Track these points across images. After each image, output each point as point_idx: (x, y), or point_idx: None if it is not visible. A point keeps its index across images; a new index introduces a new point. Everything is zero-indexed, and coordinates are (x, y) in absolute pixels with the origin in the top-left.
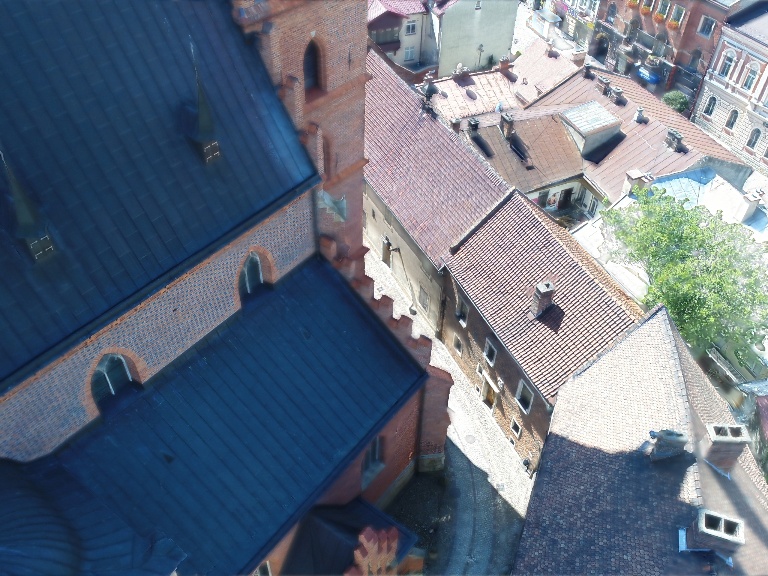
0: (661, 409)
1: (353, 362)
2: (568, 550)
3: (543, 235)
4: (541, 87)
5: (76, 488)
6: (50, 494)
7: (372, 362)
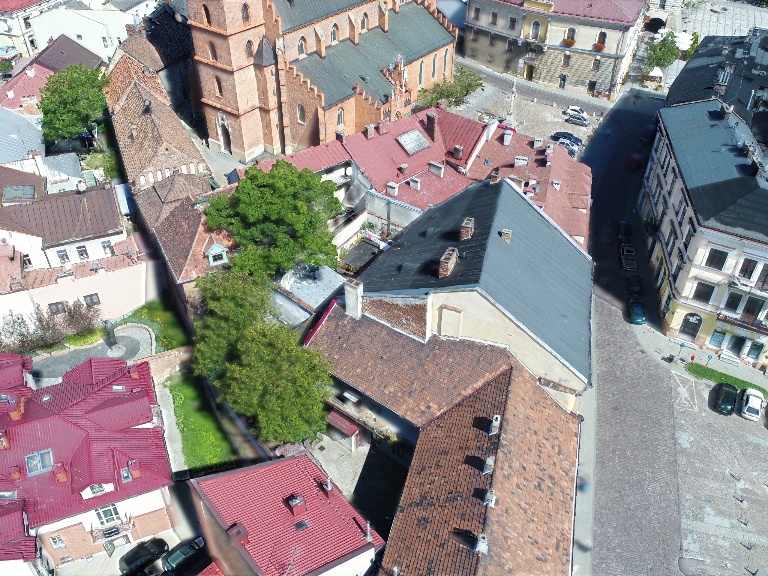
0: None
1: None
2: None
3: None
4: (12, 251)
5: None
6: None
7: None
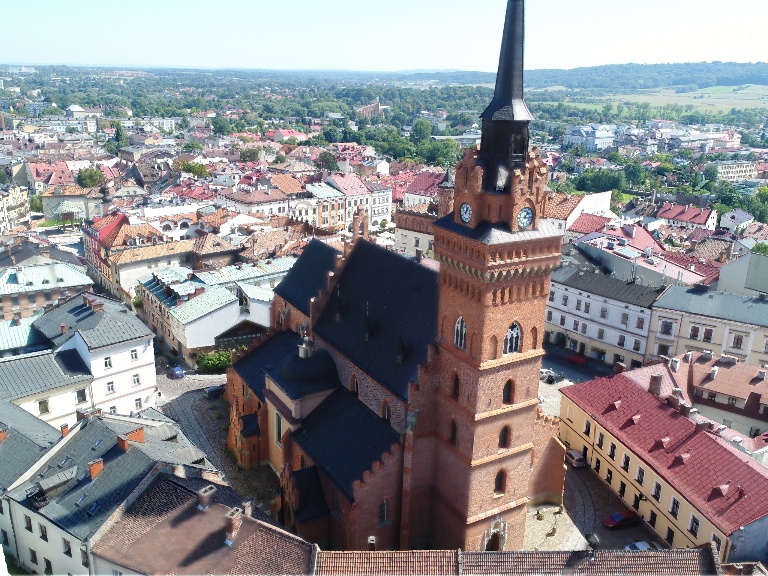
0: None
1: None
2: None
3: None
4: None
5: (328, 388)
6: (327, 382)
7: None
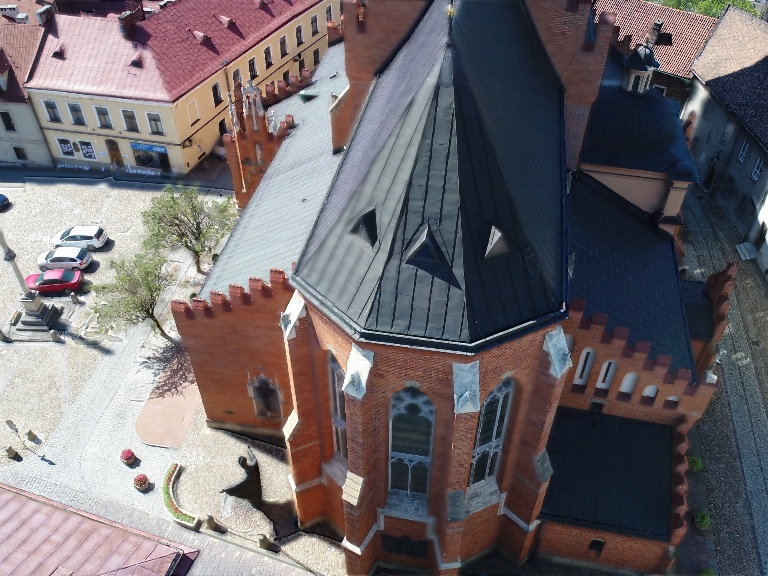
0: (765, 37)
1: (614, 66)
2: (767, 101)
3: (635, 3)
4: None
5: None
6: None
7: (619, 66)
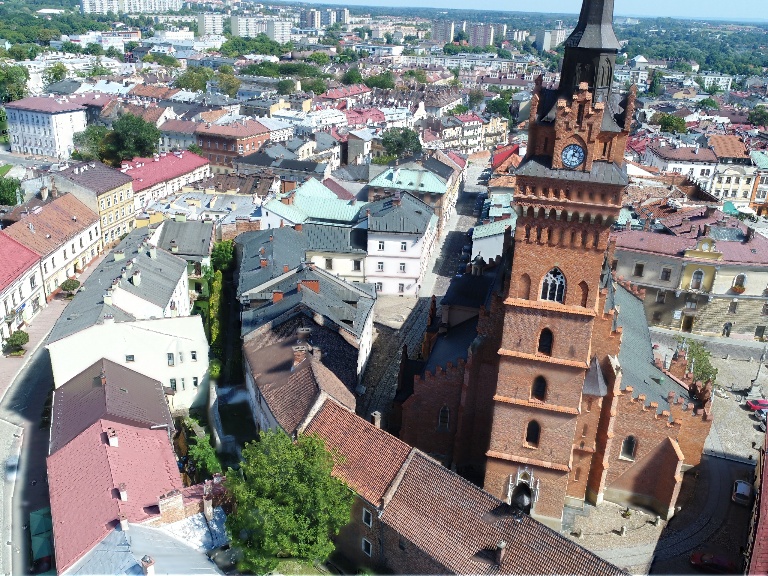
0: None
1: None
2: None
3: None
4: None
5: (479, 306)
6: (482, 301)
7: None
